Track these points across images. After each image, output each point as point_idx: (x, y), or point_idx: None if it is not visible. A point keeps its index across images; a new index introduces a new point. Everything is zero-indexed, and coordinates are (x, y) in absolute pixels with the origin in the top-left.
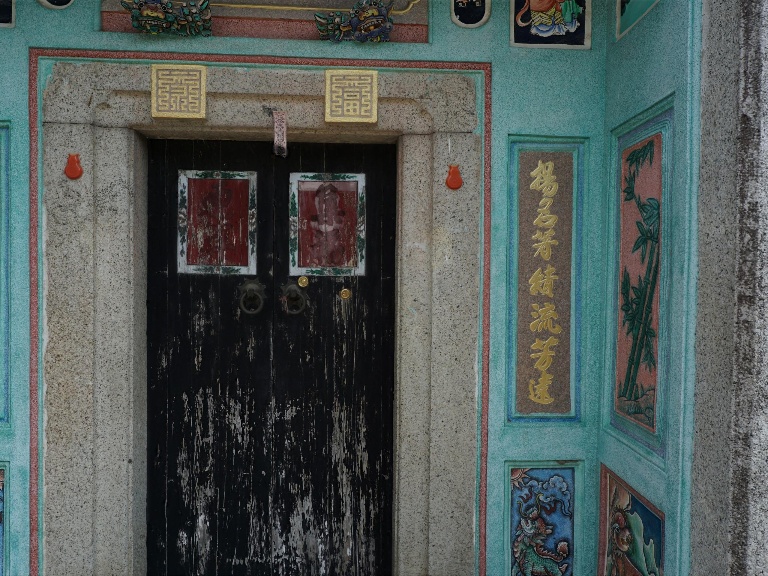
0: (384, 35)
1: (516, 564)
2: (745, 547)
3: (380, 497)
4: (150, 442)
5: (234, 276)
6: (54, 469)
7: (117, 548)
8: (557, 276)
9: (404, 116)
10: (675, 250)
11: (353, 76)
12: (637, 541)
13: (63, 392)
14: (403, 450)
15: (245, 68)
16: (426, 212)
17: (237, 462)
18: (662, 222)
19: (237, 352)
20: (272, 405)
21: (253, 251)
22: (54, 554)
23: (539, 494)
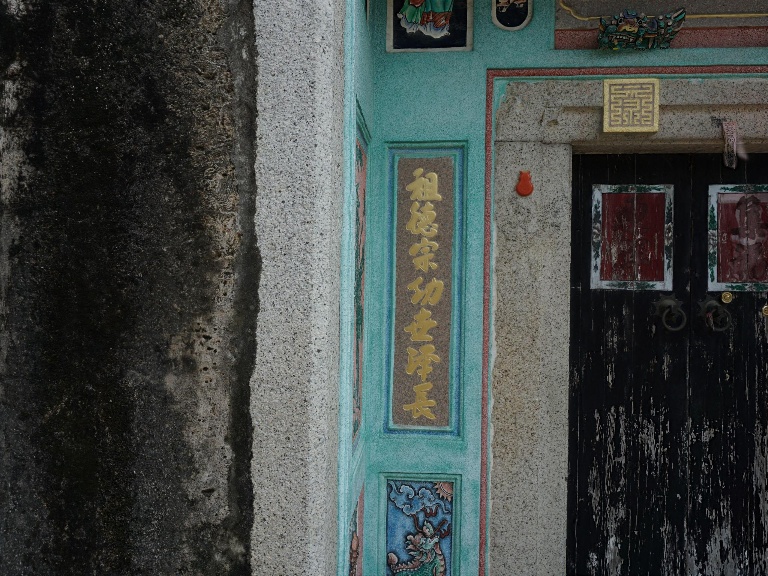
0: None
1: None
2: None
3: None
4: None
5: (649, 292)
6: (500, 484)
7: (555, 567)
8: None
9: None
10: None
11: None
12: None
13: (510, 407)
14: None
15: (699, 79)
16: None
17: (650, 484)
18: None
19: (651, 370)
20: (688, 426)
21: (669, 266)
22: (498, 569)
23: None
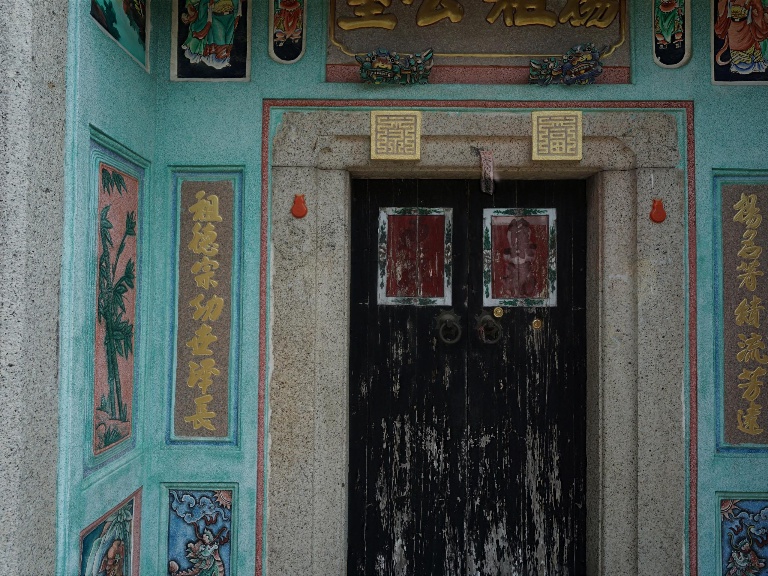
0: (591, 78)
1: None
2: None
3: (573, 526)
4: (351, 467)
5: (431, 307)
6: (277, 491)
7: (332, 569)
8: (763, 306)
9: (605, 153)
10: None
11: (559, 117)
12: None
13: (286, 417)
14: (608, 479)
15: (457, 112)
16: (628, 245)
17: (433, 488)
18: None
19: (433, 380)
20: (467, 432)
21: (449, 283)
22: (275, 573)
23: (750, 526)
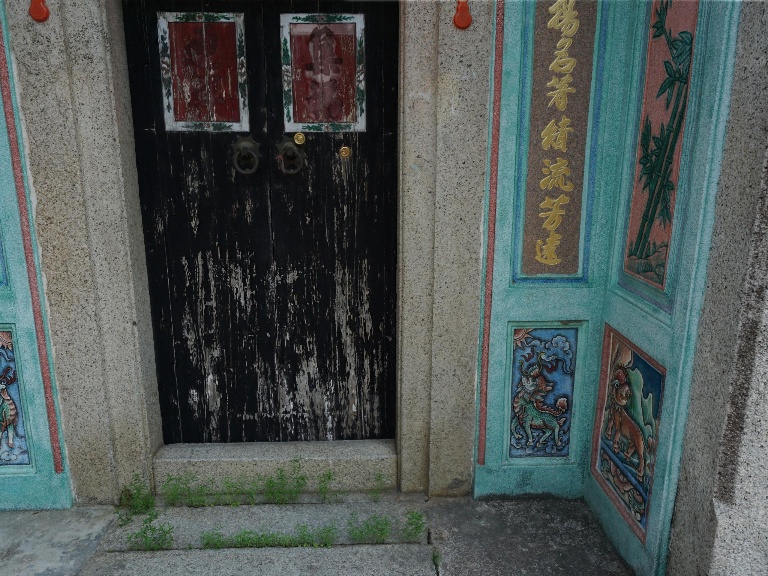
0: None
1: (515, 418)
2: (745, 398)
3: (384, 357)
4: (153, 306)
5: (226, 133)
6: (60, 331)
7: (130, 404)
8: (572, 128)
9: None
10: (705, 90)
11: None
12: (636, 396)
13: (59, 255)
14: (406, 312)
15: None
16: (431, 57)
17: (241, 325)
18: (694, 59)
19: (234, 215)
20: (273, 269)
21: (245, 105)
22: (70, 409)
23: (541, 353)
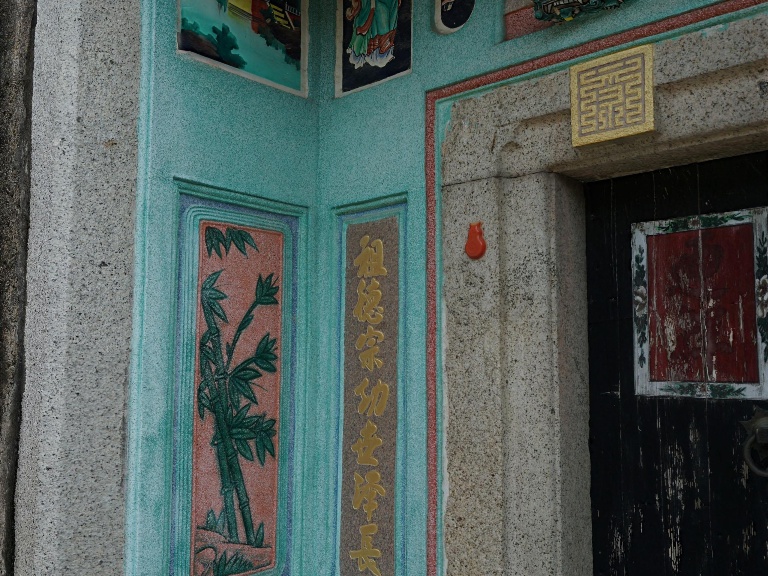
0: None
1: None
2: None
3: None
4: None
5: (733, 402)
6: None
7: None
8: None
9: None
10: None
11: None
12: None
13: (466, 575)
14: None
15: (720, 25)
16: None
17: None
18: None
19: (746, 547)
20: None
21: (767, 355)
22: None
23: None
